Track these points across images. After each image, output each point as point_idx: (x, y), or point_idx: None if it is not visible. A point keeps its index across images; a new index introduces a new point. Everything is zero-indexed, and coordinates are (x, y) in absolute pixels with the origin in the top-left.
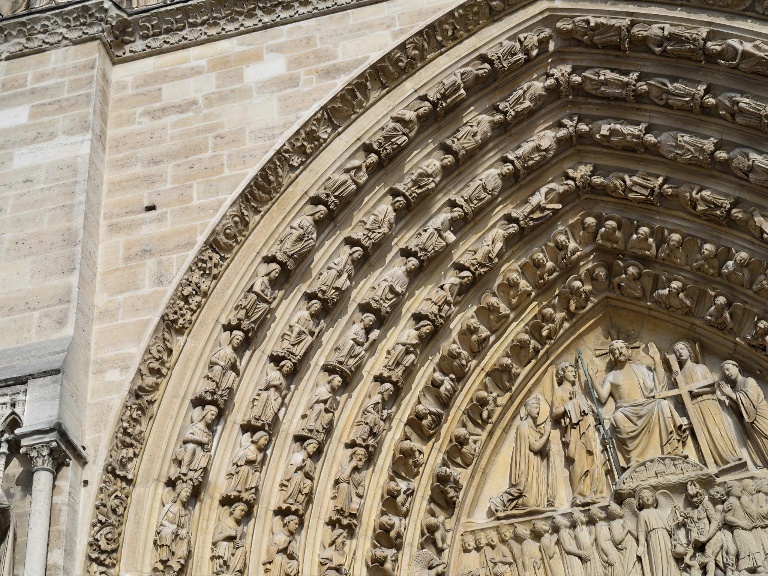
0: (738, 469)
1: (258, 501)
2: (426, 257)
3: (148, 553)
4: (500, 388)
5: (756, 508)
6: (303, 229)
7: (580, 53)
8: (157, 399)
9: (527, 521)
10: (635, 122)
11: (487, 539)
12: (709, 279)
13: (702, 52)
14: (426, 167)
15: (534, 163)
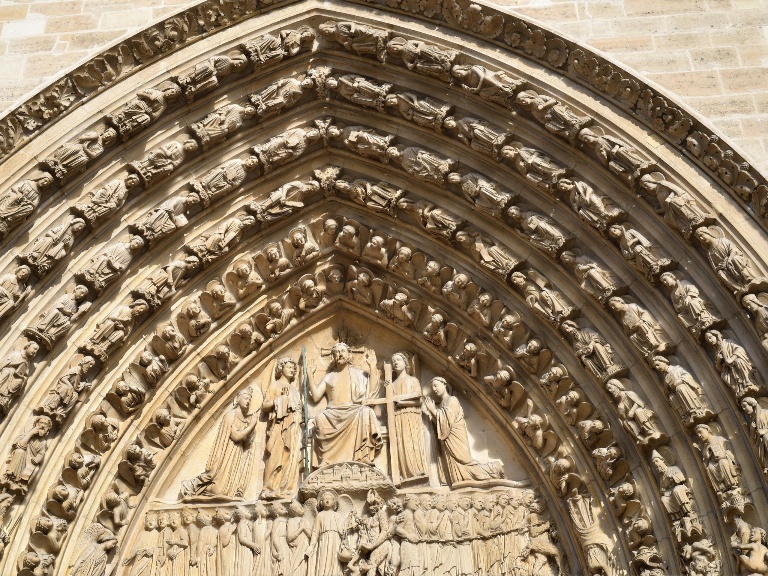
0: (420, 483)
1: None
2: (152, 237)
3: None
4: (215, 375)
5: (426, 523)
6: (23, 193)
7: (341, 57)
8: None
9: (212, 508)
10: (384, 133)
11: (169, 520)
12: (433, 296)
13: (450, 74)
14: (166, 148)
15: (280, 159)
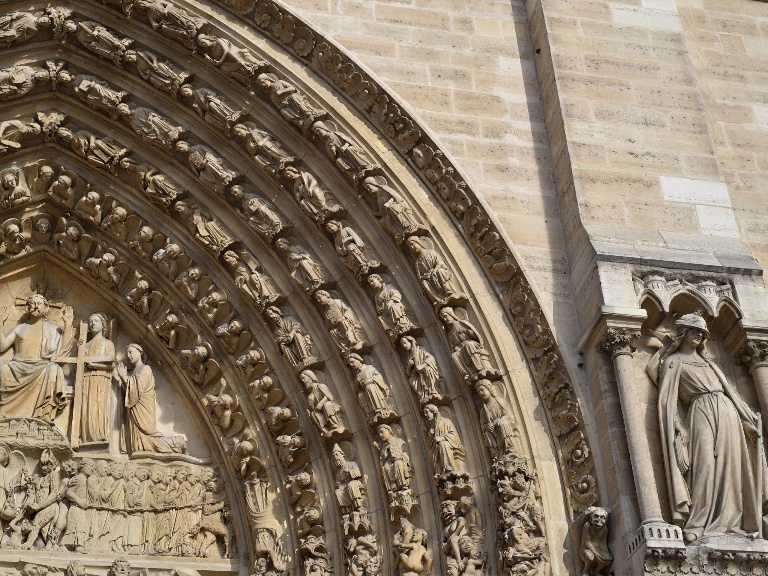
0: (99, 449)
1: None
2: None
3: None
4: None
5: (99, 490)
6: None
7: (84, 2)
8: None
9: None
10: (117, 88)
11: None
12: (142, 261)
13: (194, 41)
14: None
15: (2, 94)
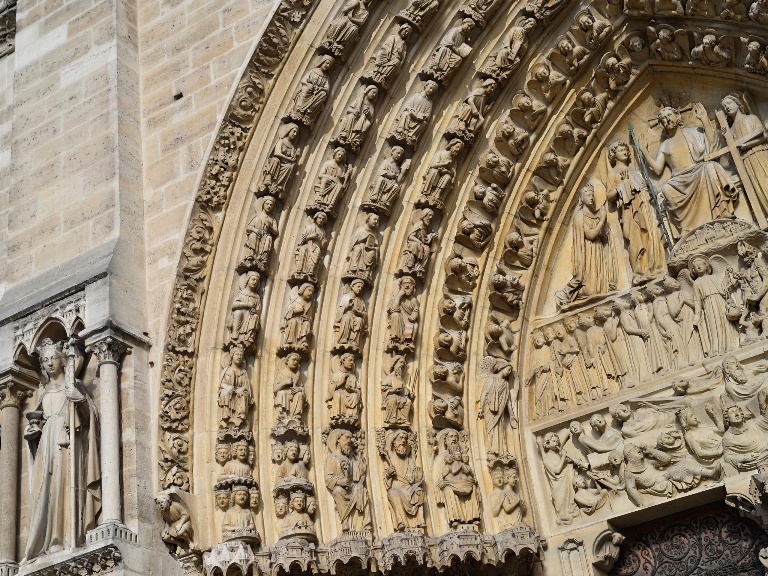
0: None
1: (315, 346)
2: (443, 76)
3: (215, 414)
4: (551, 183)
5: None
6: (312, 83)
7: None
8: (206, 275)
9: (590, 309)
10: None
11: (554, 333)
12: (742, 25)
13: None
14: None
15: None
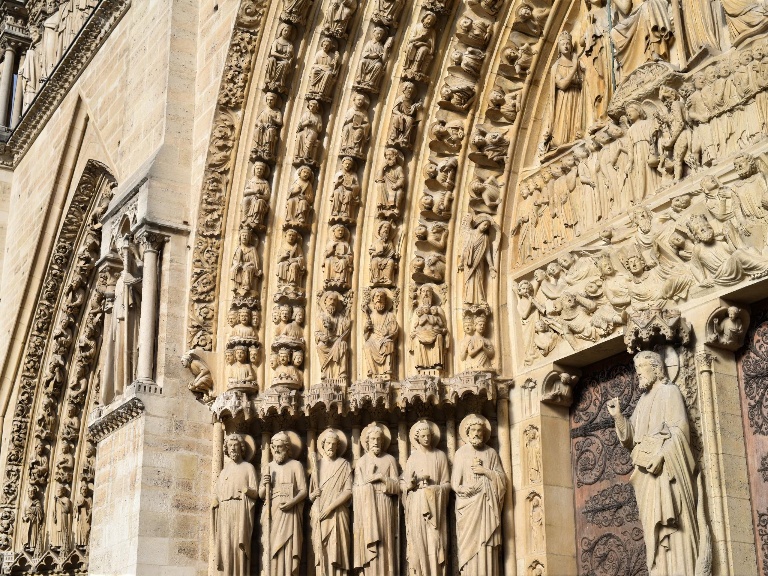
0: (704, 57)
1: (315, 220)
2: None
3: None
4: (533, 36)
5: (712, 97)
6: None
7: None
8: (230, 167)
9: None
10: None
11: (534, 184)
12: None
13: None
14: None
15: None
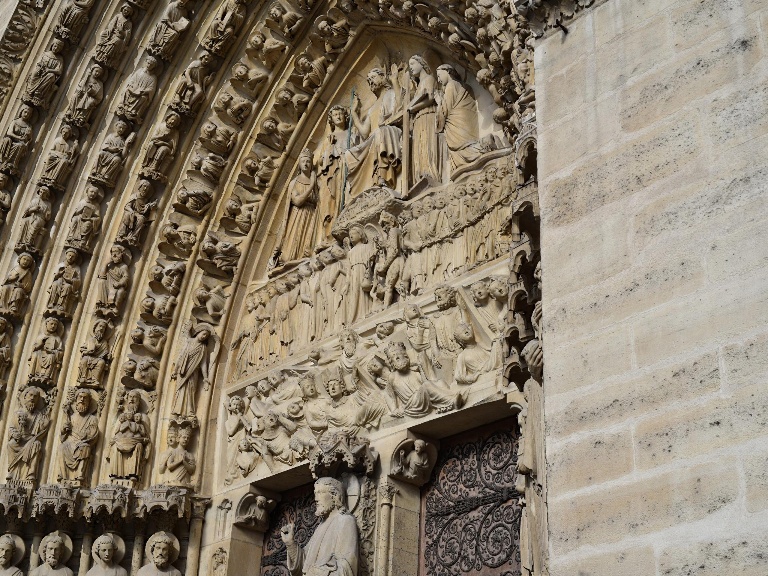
0: (424, 187)
1: (30, 310)
2: (161, 51)
3: None
4: (276, 150)
5: (425, 227)
6: (41, 66)
7: None
8: None
9: None
10: None
11: None
12: None
13: None
14: None
15: None
